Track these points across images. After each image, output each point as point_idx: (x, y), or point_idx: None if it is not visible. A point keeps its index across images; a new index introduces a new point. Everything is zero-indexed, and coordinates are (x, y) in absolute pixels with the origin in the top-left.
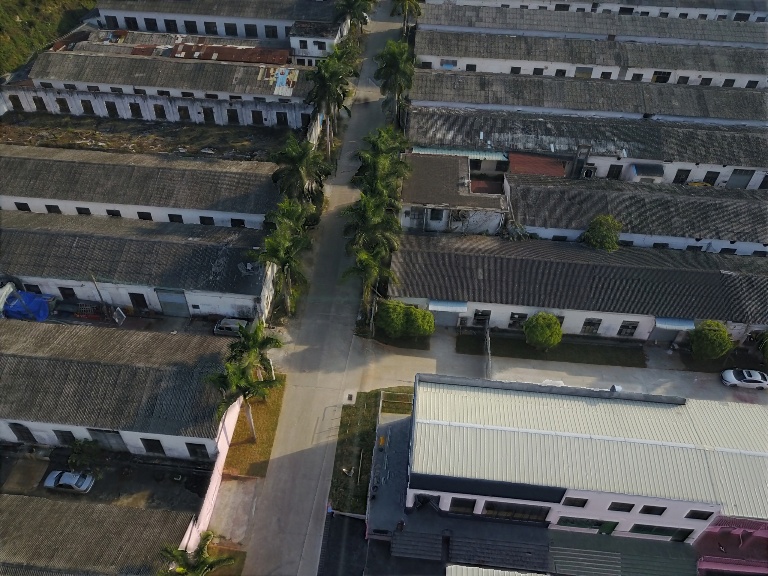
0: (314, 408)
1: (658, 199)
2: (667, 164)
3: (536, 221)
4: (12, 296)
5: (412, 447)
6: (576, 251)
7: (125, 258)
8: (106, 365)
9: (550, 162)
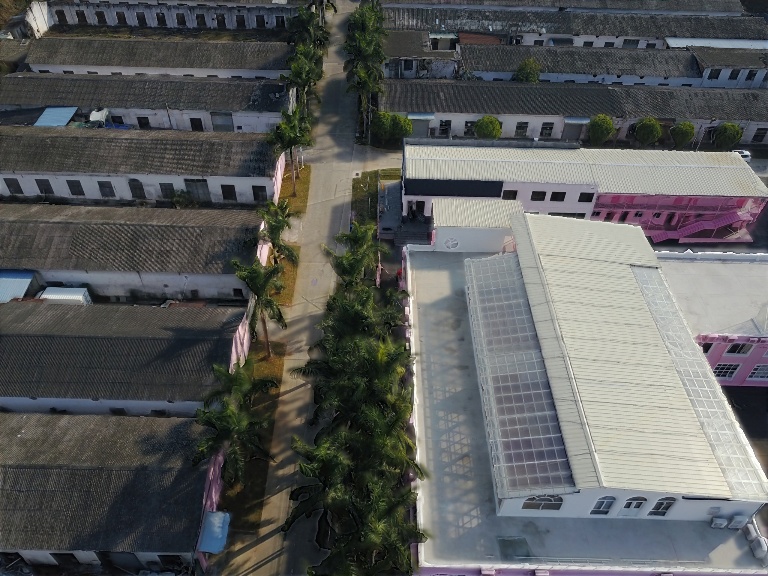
0: (333, 180)
1: (566, 51)
2: (576, 38)
3: (480, 67)
4: (107, 119)
5: (405, 168)
6: (509, 83)
7: (186, 93)
8: (192, 141)
9: (489, 38)
